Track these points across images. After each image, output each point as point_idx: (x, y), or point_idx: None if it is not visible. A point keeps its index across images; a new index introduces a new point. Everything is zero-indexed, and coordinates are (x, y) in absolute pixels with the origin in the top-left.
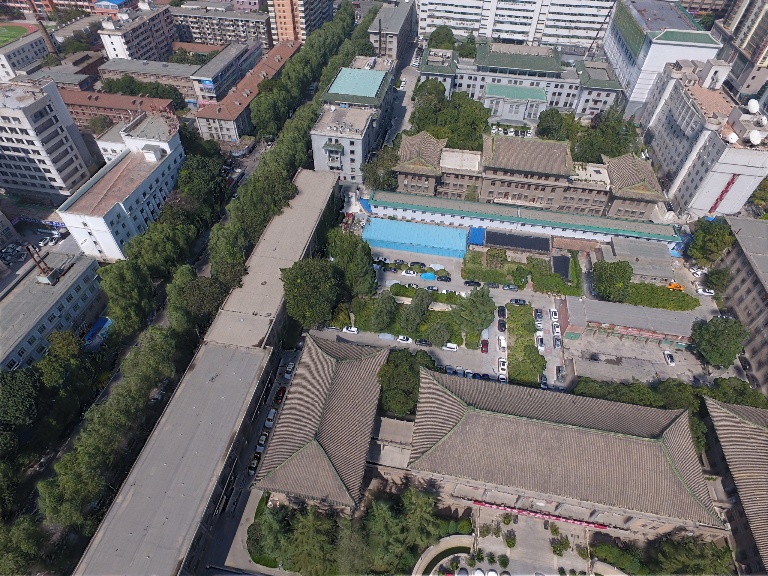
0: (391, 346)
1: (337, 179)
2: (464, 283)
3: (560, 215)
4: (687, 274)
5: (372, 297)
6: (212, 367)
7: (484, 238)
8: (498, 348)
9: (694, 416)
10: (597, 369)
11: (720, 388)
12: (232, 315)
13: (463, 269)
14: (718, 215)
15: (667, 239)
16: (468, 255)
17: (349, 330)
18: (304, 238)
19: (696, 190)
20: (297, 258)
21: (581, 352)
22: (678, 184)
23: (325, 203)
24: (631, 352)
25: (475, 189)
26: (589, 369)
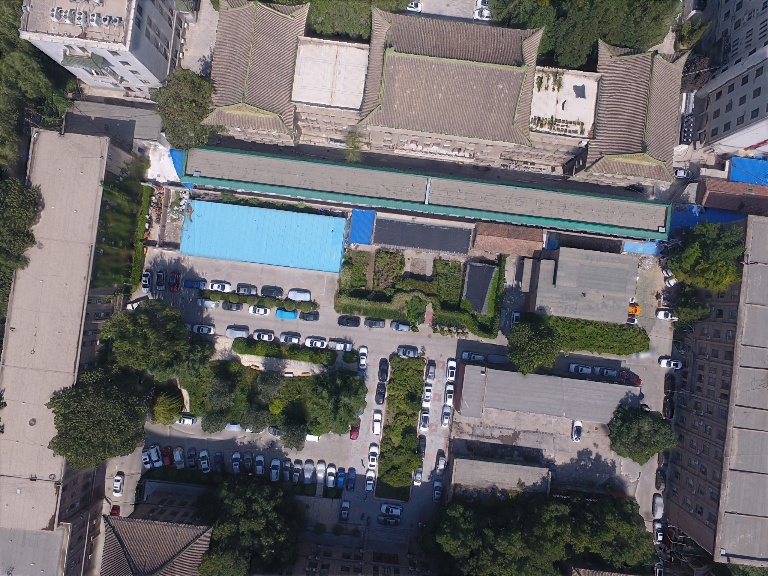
0: (239, 437)
1: (108, 152)
2: (337, 321)
3: (494, 190)
4: (657, 278)
5: (209, 359)
6: (3, 557)
7: (372, 233)
8: (371, 429)
9: (560, 564)
10: (480, 472)
11: (602, 534)
12: (3, 483)
13: (337, 295)
14: (757, 152)
15: (647, 237)
16: (343, 277)
17: (182, 423)
18: (73, 321)
19: (738, 128)
20: (70, 367)
21: (473, 427)
22: (721, 83)
23: (94, 229)
24: (534, 423)
25: (362, 127)
26: (470, 473)
